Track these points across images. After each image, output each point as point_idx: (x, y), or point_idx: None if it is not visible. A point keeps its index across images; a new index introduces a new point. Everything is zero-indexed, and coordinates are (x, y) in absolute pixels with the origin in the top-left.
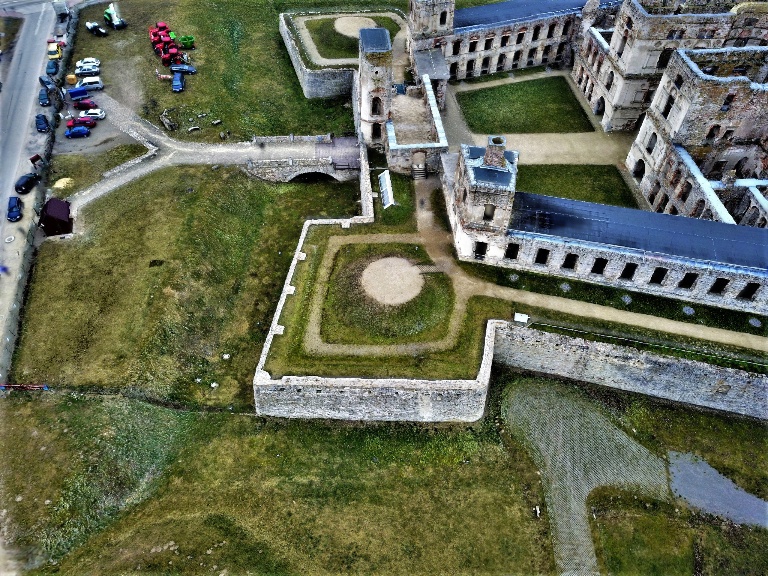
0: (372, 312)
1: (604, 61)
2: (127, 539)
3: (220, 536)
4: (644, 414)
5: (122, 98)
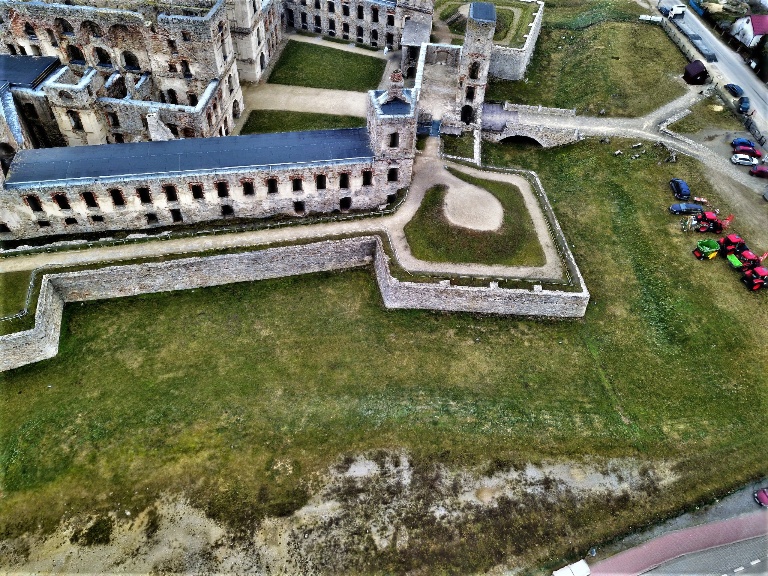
0: None
1: (222, 88)
2: (583, 4)
3: (548, 1)
4: None
5: (732, 183)
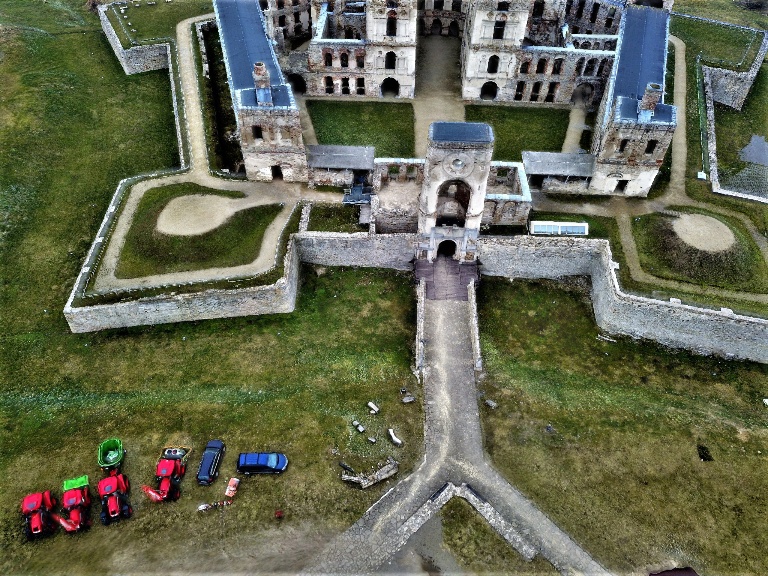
0: (741, 252)
1: (368, 52)
2: None
3: None
4: (717, 162)
5: (286, 566)
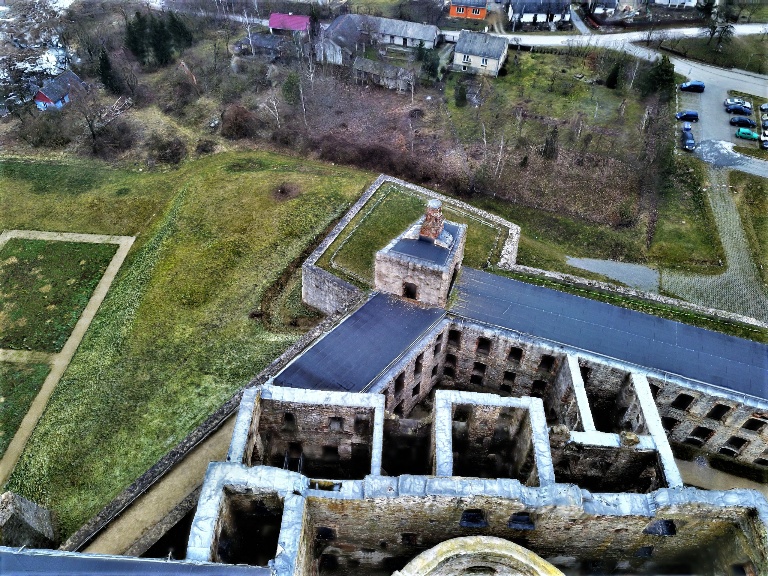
0: None
1: None
2: None
3: None
4: None
5: None
